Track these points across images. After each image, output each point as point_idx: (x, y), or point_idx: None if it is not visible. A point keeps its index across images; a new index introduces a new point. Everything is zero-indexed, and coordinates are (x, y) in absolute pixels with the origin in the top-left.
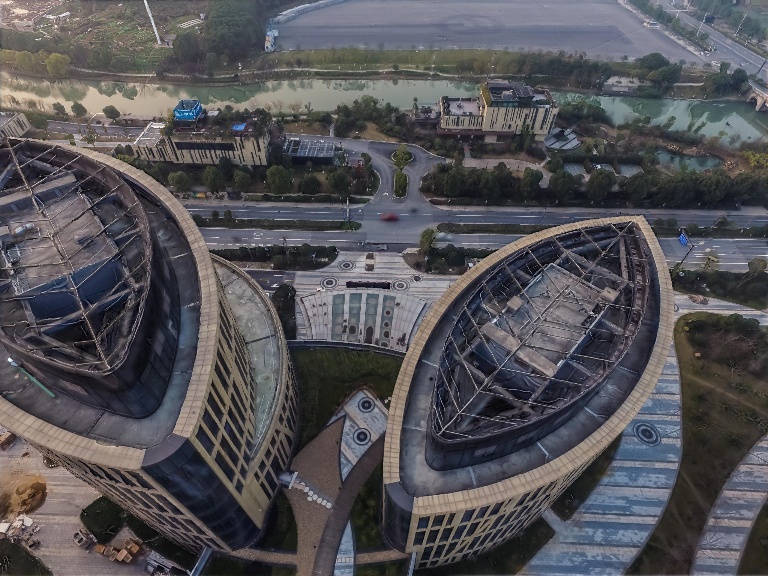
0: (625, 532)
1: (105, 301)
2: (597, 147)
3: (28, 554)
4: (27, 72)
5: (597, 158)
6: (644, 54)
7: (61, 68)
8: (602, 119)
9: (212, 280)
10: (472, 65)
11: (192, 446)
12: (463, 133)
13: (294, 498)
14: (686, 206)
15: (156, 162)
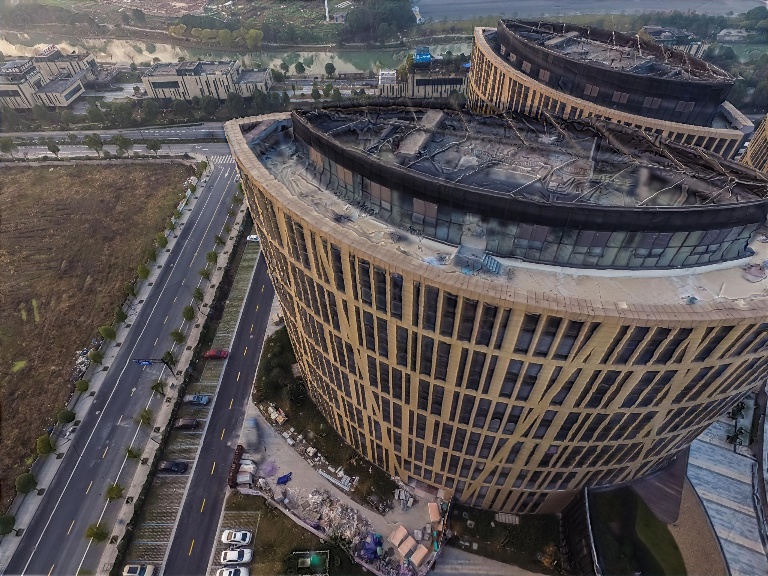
0: None
1: (672, 73)
2: (742, 74)
3: None
4: (223, 48)
5: (744, 82)
6: (743, 11)
7: (259, 41)
8: (731, 58)
9: None
10: (601, 25)
11: None
12: None
13: None
14: None
15: (391, 99)
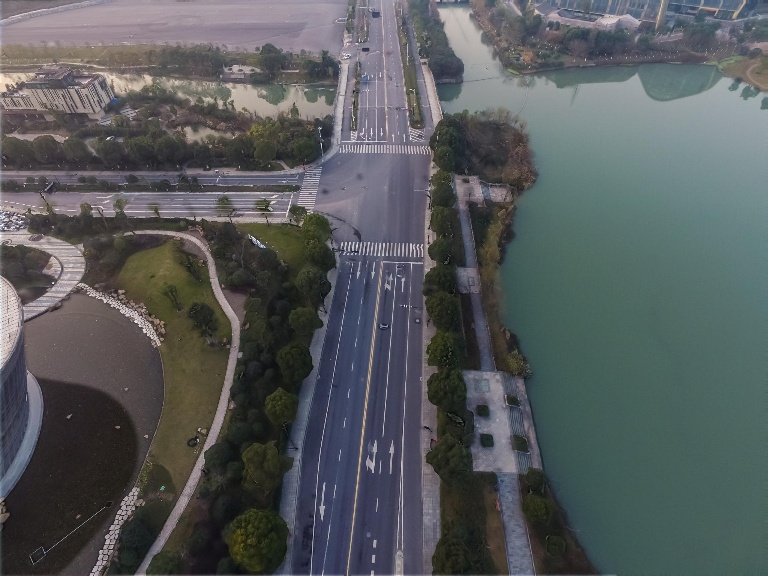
0: None
1: None
2: None
3: None
4: None
5: (112, 131)
6: None
7: None
8: (172, 100)
9: None
10: None
11: None
12: (20, 113)
13: None
14: (133, 168)
15: None
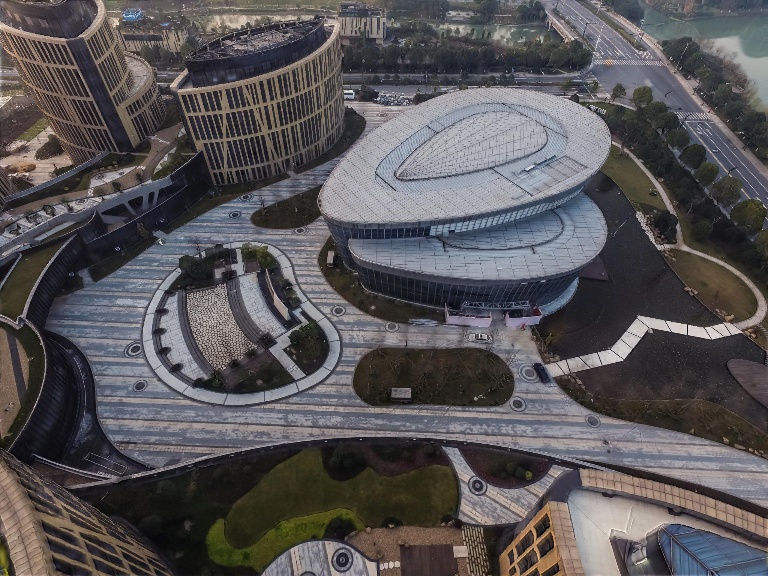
0: (325, 177)
1: None
2: None
3: (27, 182)
4: None
5: None
6: None
7: None
8: (429, 32)
9: (103, 11)
10: None
11: (86, 44)
12: None
13: (153, 141)
14: (452, 71)
15: None
